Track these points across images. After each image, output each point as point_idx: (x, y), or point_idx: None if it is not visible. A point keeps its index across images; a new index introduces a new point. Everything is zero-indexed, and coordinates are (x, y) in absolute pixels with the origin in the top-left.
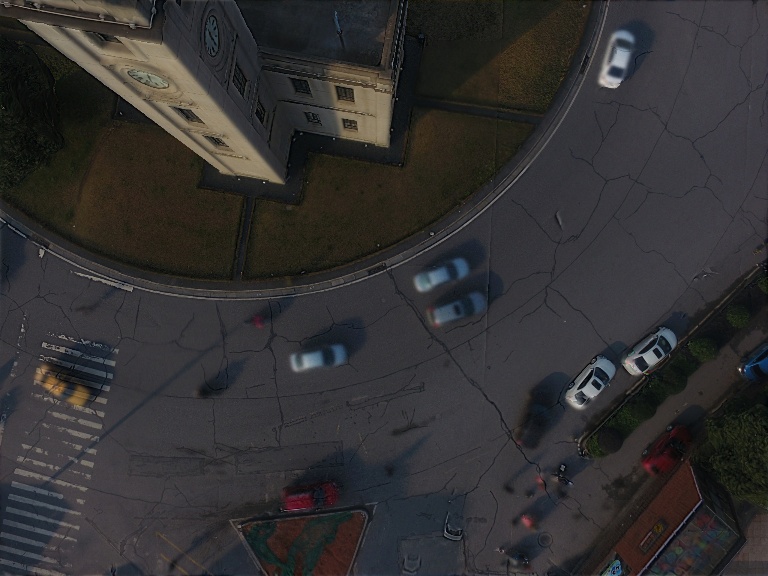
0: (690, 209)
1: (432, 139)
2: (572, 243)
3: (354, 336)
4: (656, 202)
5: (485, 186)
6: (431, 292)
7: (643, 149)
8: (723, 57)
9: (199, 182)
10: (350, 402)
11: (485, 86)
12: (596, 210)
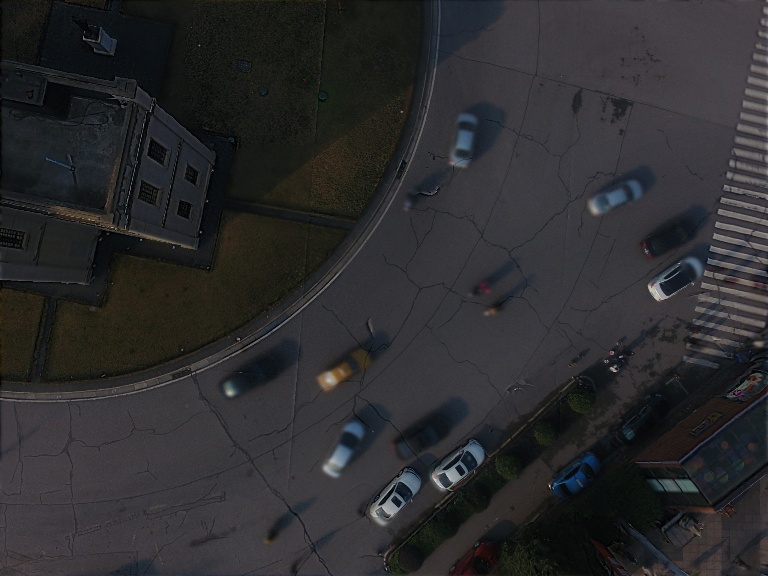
0: (505, 319)
1: (241, 243)
2: (383, 351)
3: (155, 442)
4: (471, 311)
5: (294, 292)
6: (236, 398)
7: (458, 257)
8: (542, 166)
9: None
10: (147, 511)
11: (297, 190)
12: (408, 318)
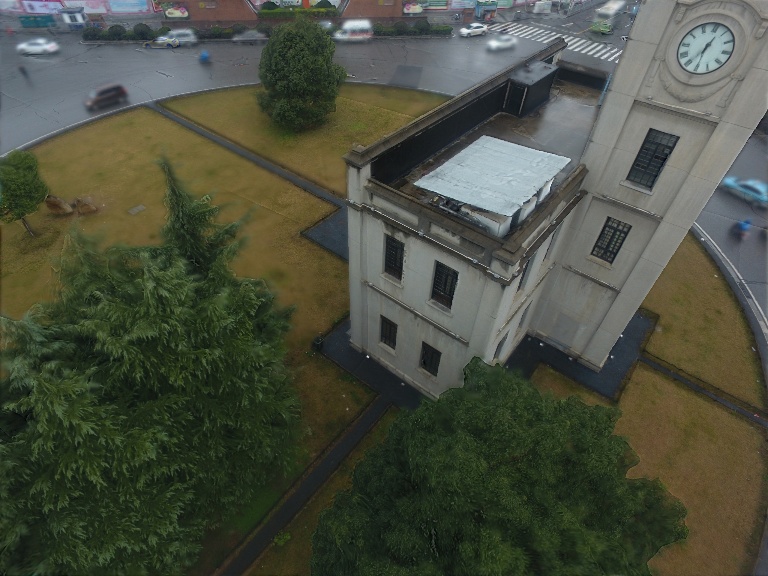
0: None
1: None
2: None
3: None
4: None
5: None
6: None
7: None
8: None
9: (609, 398)
10: None
11: None
12: None
